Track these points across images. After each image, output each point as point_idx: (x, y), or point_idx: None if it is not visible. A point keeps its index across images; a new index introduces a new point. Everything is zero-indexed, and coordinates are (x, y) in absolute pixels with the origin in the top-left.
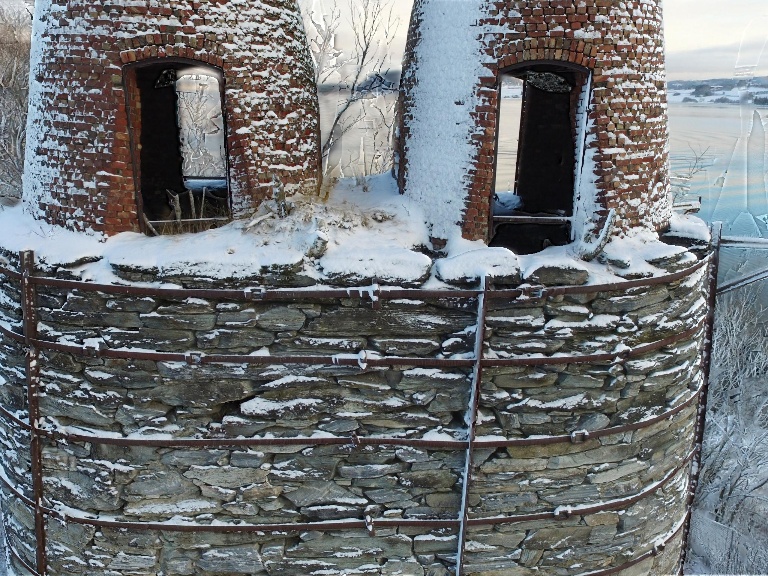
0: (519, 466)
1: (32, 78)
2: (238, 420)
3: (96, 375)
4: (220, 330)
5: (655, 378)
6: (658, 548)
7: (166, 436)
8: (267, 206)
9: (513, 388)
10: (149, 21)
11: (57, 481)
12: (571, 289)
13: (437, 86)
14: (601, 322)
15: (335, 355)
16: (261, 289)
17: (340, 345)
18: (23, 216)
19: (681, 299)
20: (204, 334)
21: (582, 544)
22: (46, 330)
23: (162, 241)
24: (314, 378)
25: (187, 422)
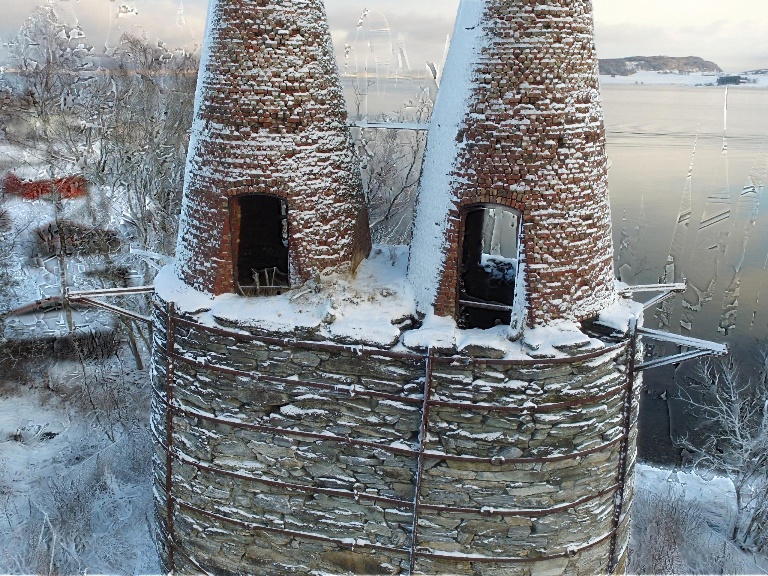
0: (455, 474)
1: (184, 193)
2: (279, 417)
3: (202, 378)
4: (271, 361)
5: (560, 428)
6: (572, 552)
7: (238, 420)
8: (308, 285)
9: (451, 421)
10: (245, 171)
11: (180, 437)
12: (490, 361)
13: (427, 209)
14: (513, 385)
15: (337, 385)
16: (294, 340)
17: (340, 379)
18: (174, 275)
19: (584, 374)
20: (262, 362)
21: (502, 536)
22: (178, 348)
23: (244, 302)
24: (324, 397)
25: (250, 414)
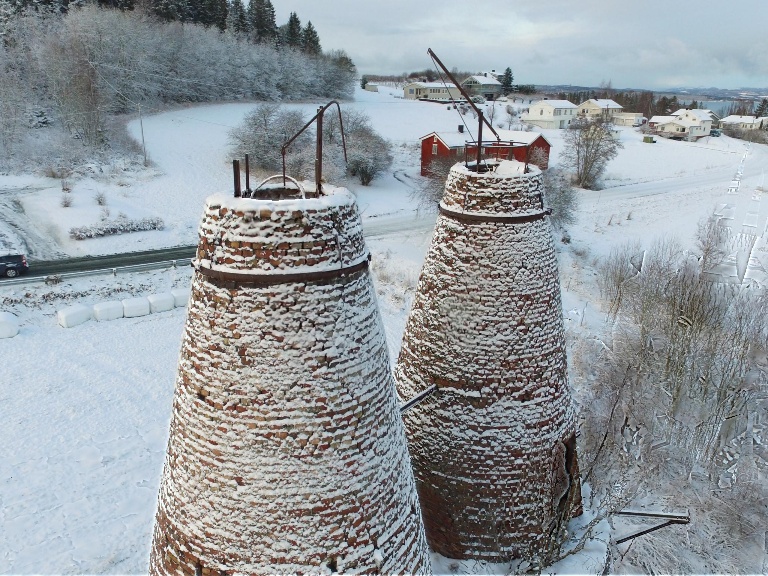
0: None
1: None
2: None
3: None
4: None
5: None
6: None
7: None
8: None
9: None
10: None
11: None
12: None
13: None
14: None
15: None
16: None
17: None
18: None
19: None
20: None
21: None
22: None
23: None
24: None
25: None
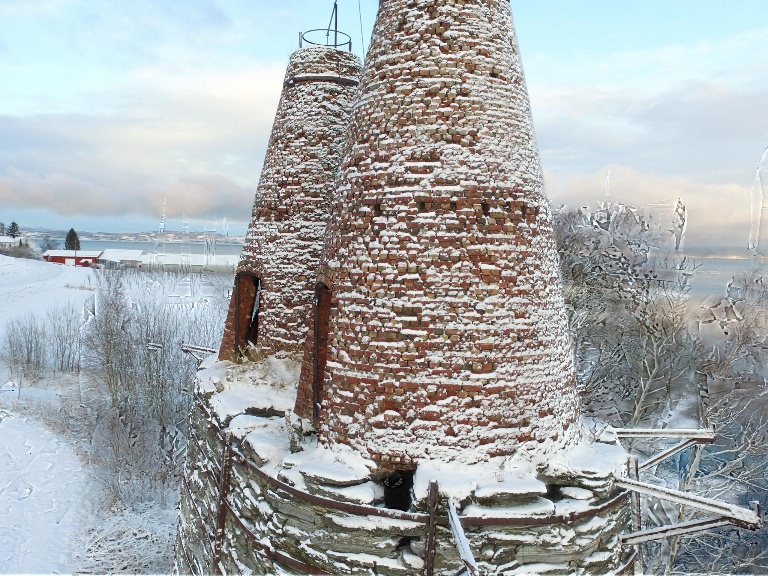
0: None
1: None
2: None
3: None
4: None
5: None
6: None
7: None
8: None
9: None
10: None
11: None
12: None
13: None
14: (261, 508)
15: None
16: None
17: None
18: None
19: (329, 532)
20: None
21: None
22: None
23: None
24: None
25: None
